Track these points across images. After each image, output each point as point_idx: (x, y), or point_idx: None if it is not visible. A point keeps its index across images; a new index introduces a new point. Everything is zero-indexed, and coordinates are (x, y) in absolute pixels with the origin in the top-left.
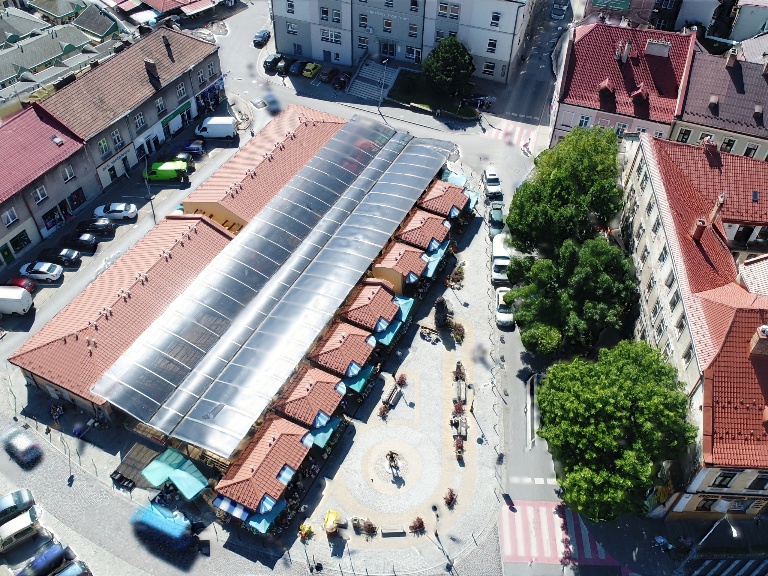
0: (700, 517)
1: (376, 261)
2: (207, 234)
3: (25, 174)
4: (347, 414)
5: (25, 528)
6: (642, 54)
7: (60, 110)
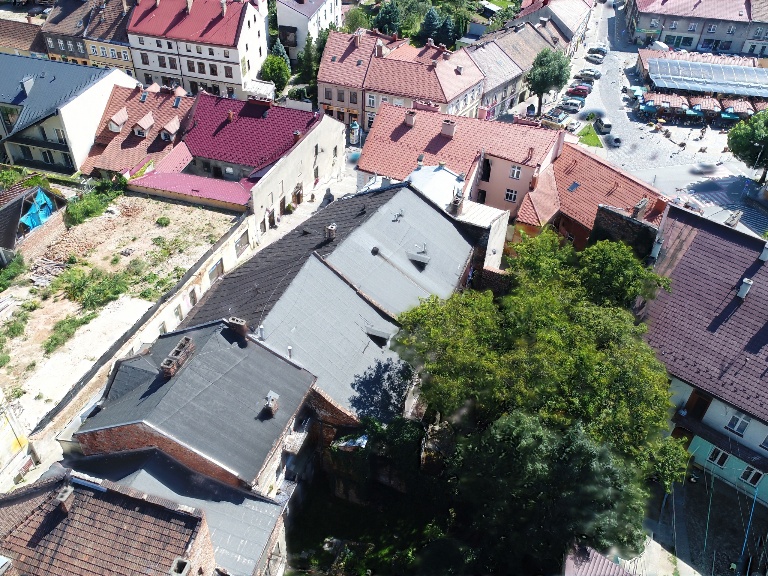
0: None
1: None
2: (749, 64)
3: (715, 14)
4: (710, 125)
5: (591, 74)
6: None
7: (757, 4)
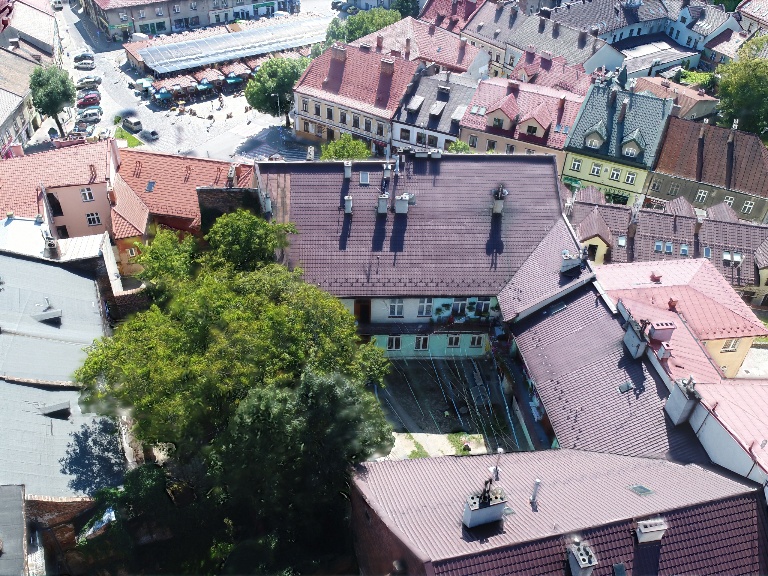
0: (307, 137)
1: (278, 52)
2: (224, 32)
3: None
4: (223, 93)
5: (91, 81)
6: (465, 0)
7: None
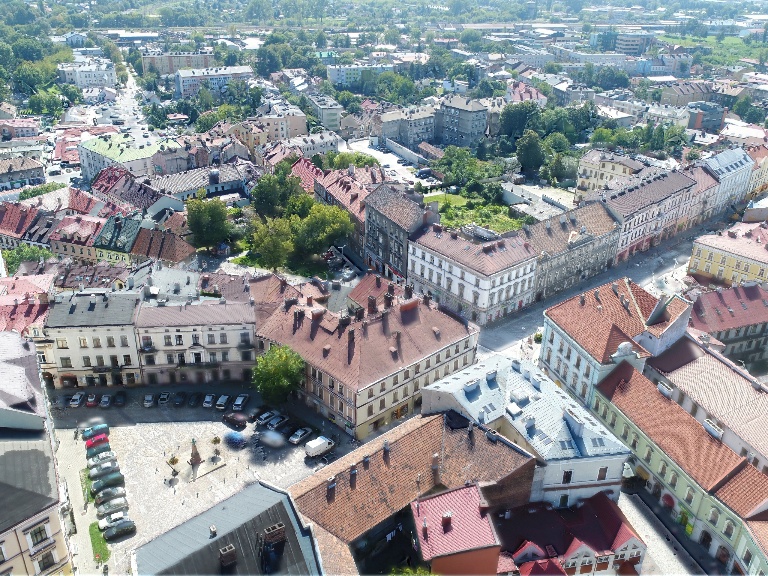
0: None
1: None
2: None
3: None
4: None
5: None
6: None
7: None
